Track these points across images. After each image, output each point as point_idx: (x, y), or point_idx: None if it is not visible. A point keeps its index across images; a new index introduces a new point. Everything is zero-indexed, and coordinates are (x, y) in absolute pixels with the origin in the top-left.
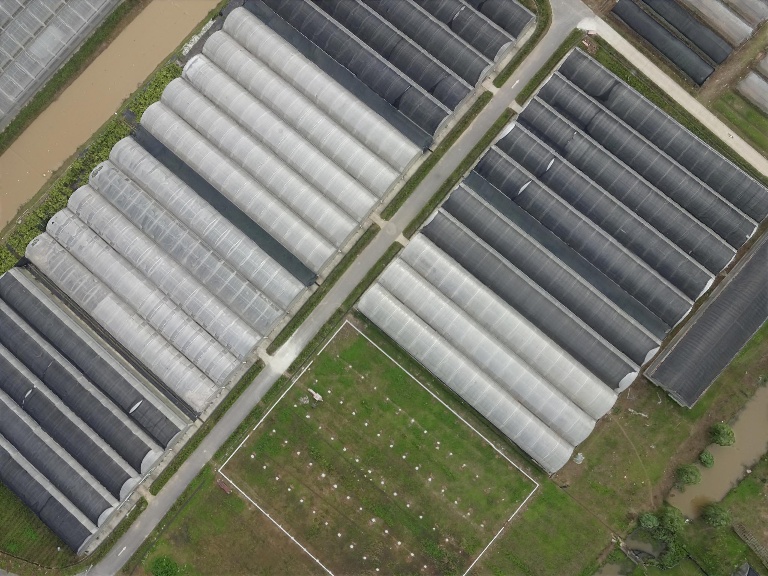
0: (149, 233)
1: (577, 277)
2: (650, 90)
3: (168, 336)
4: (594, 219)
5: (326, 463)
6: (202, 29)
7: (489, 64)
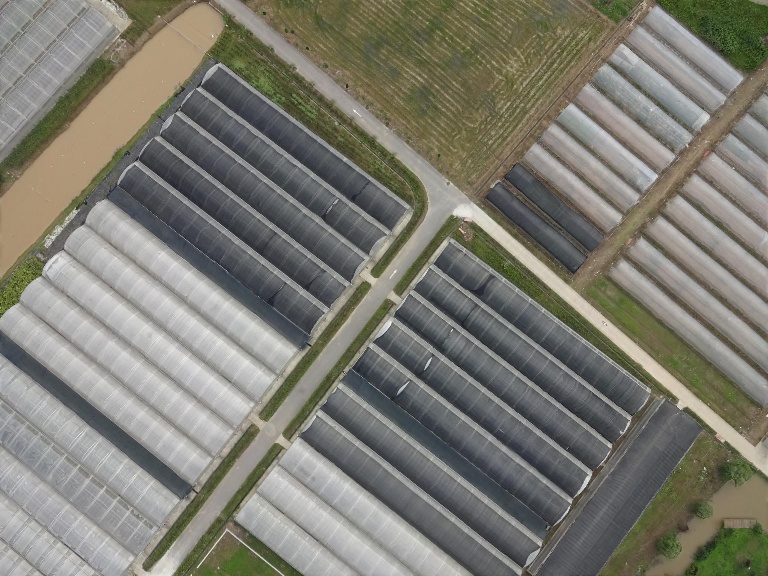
0: (10, 448)
1: (458, 479)
2: (526, 278)
3: (33, 562)
4: (473, 417)
5: None
6: (65, 219)
7: (364, 260)
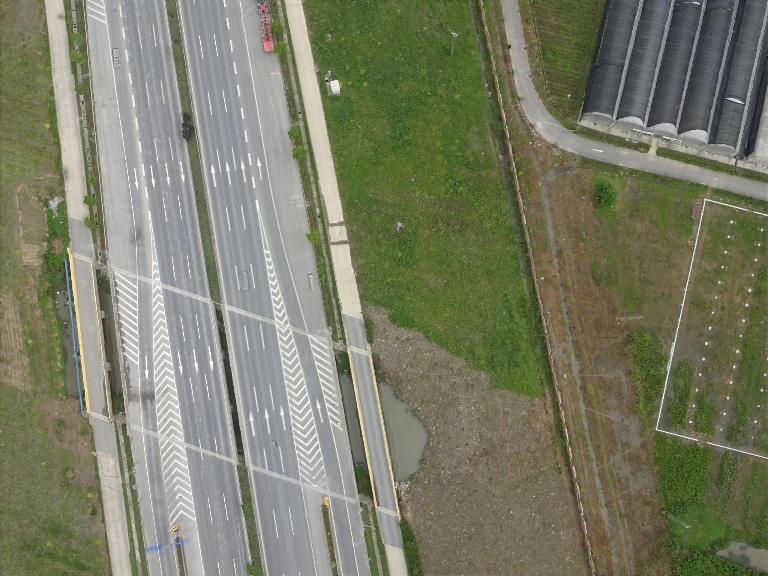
0: None
1: None
2: None
3: None
4: None
5: (763, 287)
6: None
7: None
